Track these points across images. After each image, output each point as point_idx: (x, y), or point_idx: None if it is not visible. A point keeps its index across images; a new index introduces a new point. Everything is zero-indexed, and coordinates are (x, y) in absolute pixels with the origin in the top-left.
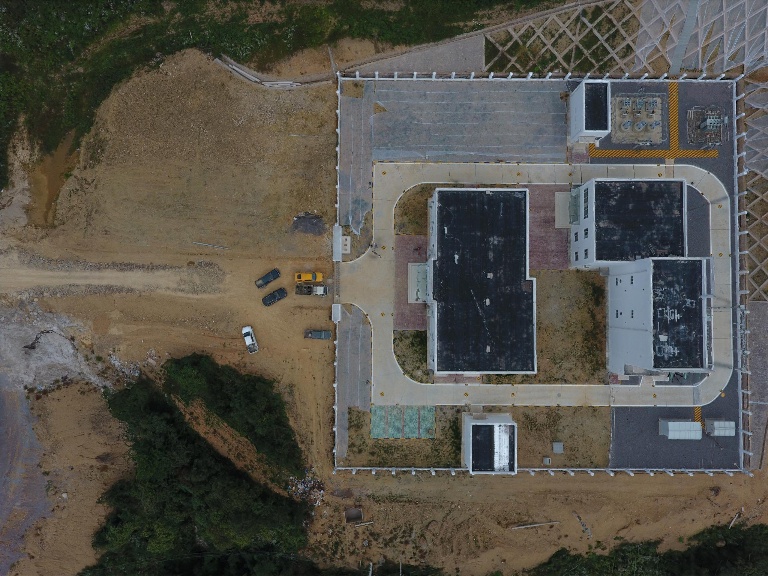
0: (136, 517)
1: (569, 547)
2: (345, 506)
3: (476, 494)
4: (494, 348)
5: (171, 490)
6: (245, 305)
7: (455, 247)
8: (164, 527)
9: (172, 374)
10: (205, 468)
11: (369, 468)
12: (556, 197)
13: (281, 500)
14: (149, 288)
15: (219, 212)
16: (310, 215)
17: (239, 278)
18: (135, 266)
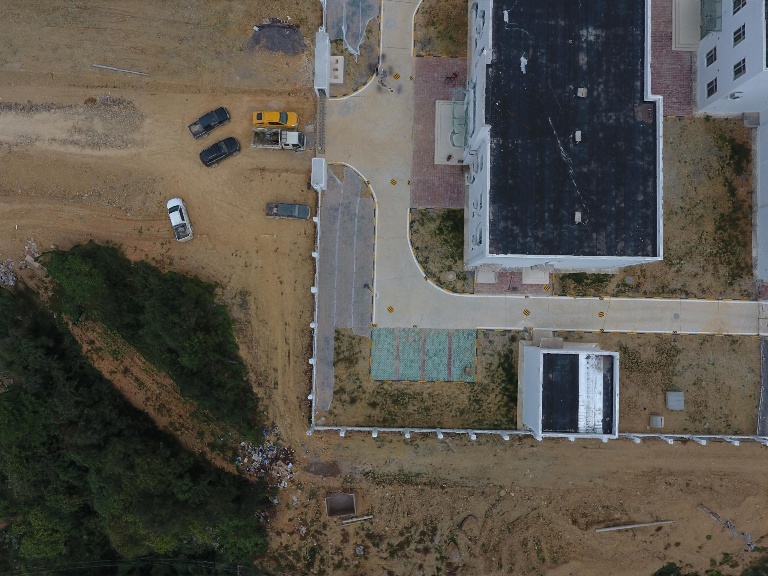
0: (2, 503)
1: (680, 562)
2: (327, 489)
3: (540, 474)
4: (587, 217)
5: (56, 461)
6: (174, 166)
7: (522, 44)
8: (45, 519)
9: (51, 271)
10: (98, 423)
11: (367, 428)
12: (674, 1)
13: (225, 479)
14: (24, 140)
15: (135, 18)
16: (280, 22)
17: (165, 124)
18: (3, 106)
